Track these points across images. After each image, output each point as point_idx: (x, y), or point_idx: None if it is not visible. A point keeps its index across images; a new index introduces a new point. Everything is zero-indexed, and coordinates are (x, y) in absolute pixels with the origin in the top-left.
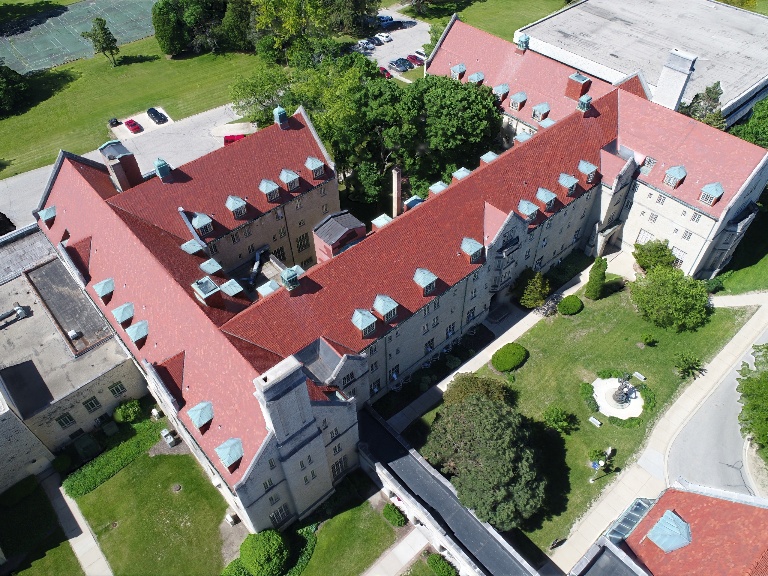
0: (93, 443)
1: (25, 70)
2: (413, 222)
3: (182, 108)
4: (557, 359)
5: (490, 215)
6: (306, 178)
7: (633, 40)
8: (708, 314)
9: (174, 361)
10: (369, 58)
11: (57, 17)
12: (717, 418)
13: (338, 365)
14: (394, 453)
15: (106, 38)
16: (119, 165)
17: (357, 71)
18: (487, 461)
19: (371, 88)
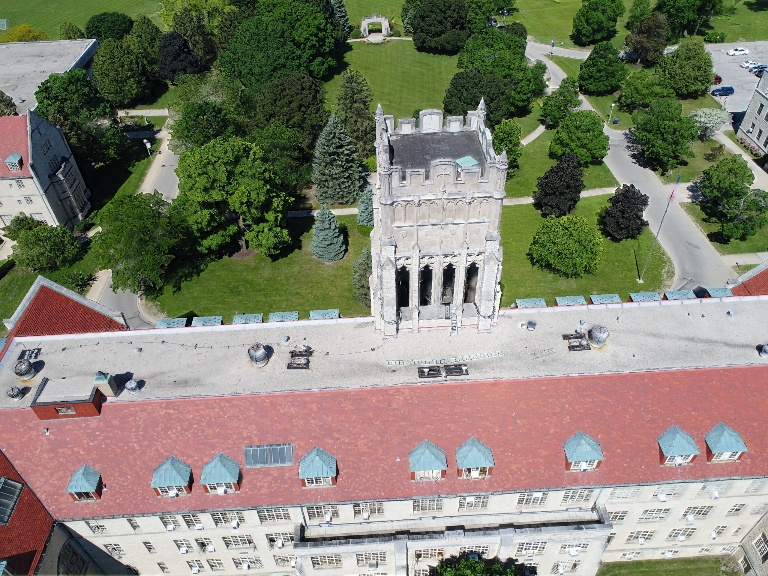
0: None
1: None
2: None
3: None
4: None
5: None
6: None
7: None
8: (88, 245)
9: None
10: None
11: None
12: (114, 298)
13: None
14: None
15: None
16: None
17: None
18: None
19: None
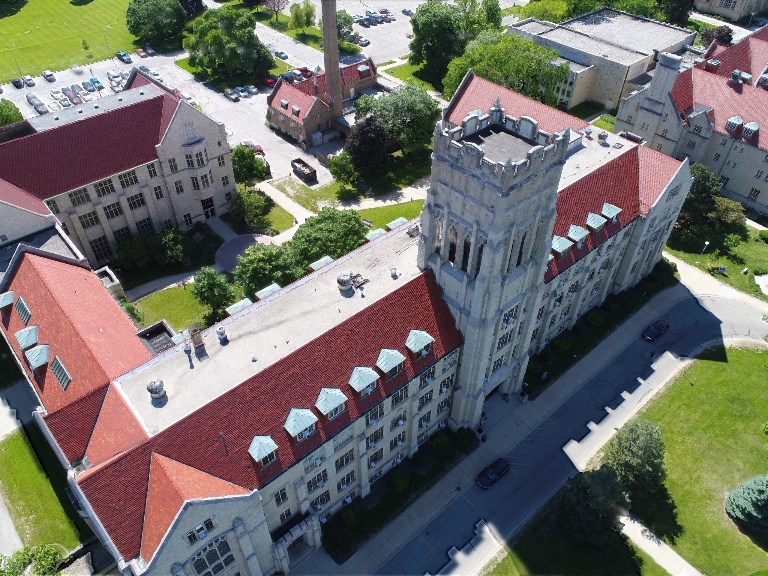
0: None
1: None
2: None
3: None
4: None
5: None
6: None
7: None
8: None
9: None
10: None
11: None
12: None
13: (699, 112)
14: None
15: None
16: None
17: None
18: None
19: None
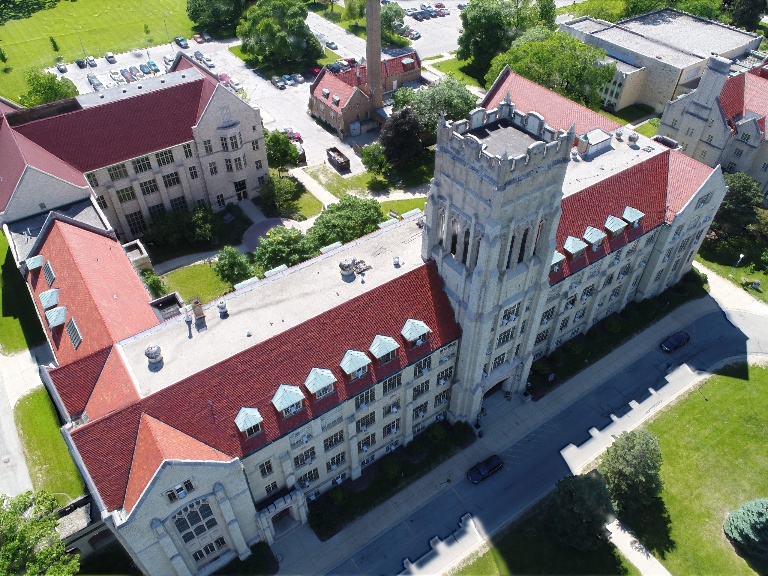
0: None
1: None
2: None
3: None
4: None
5: None
6: None
7: None
8: None
9: None
10: None
11: None
12: None
13: None
14: None
15: None
16: None
17: None
18: None
19: None
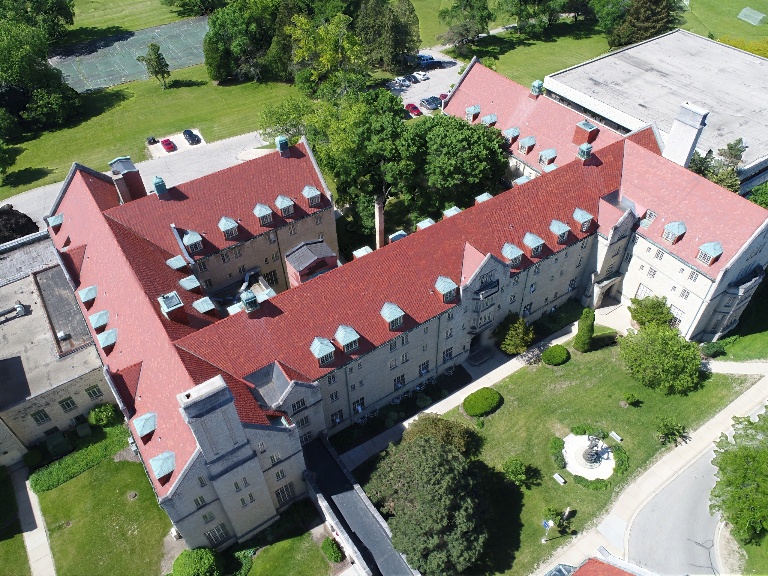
0: (63, 442)
1: (85, 88)
2: (386, 256)
3: (217, 131)
4: (532, 409)
5: (469, 256)
6: (302, 205)
7: (666, 91)
8: (703, 379)
9: (131, 370)
10: (403, 95)
11: (124, 41)
12: (693, 491)
13: (286, 391)
14: (340, 486)
15: (158, 63)
16: (122, 180)
17: (363, 106)
18: (422, 505)
19: (374, 123)
